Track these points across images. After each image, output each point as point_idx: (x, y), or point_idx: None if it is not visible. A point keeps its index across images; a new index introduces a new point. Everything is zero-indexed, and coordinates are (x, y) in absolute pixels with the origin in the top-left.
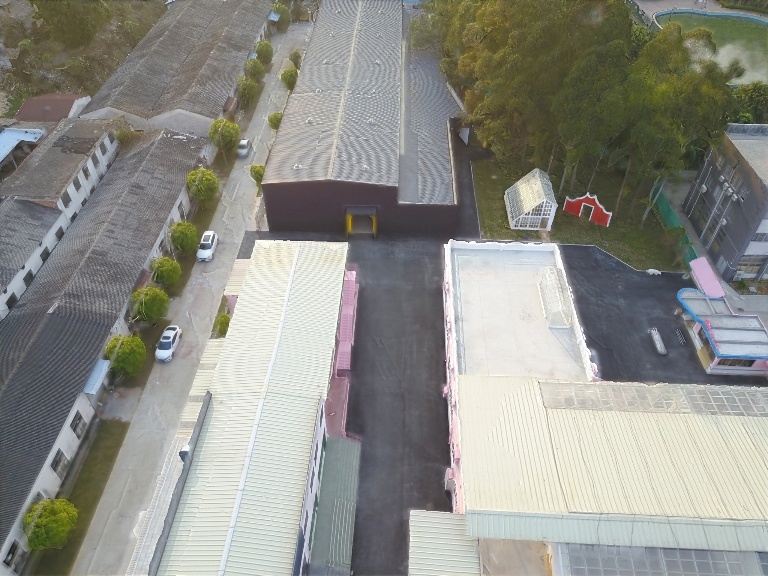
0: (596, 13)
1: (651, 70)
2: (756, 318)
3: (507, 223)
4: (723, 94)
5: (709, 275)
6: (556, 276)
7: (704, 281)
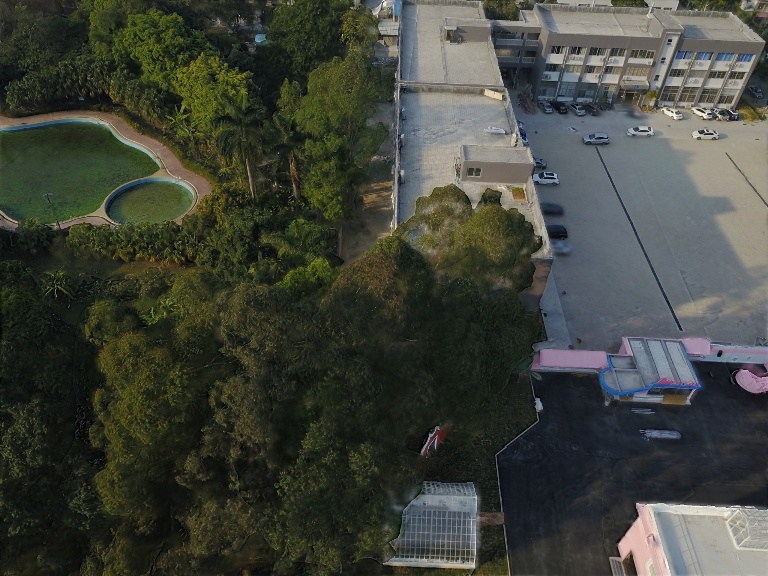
0: (398, 281)
1: (507, 272)
2: (630, 340)
3: (461, 572)
4: (525, 227)
5: (572, 355)
6: (765, 519)
7: (577, 363)
